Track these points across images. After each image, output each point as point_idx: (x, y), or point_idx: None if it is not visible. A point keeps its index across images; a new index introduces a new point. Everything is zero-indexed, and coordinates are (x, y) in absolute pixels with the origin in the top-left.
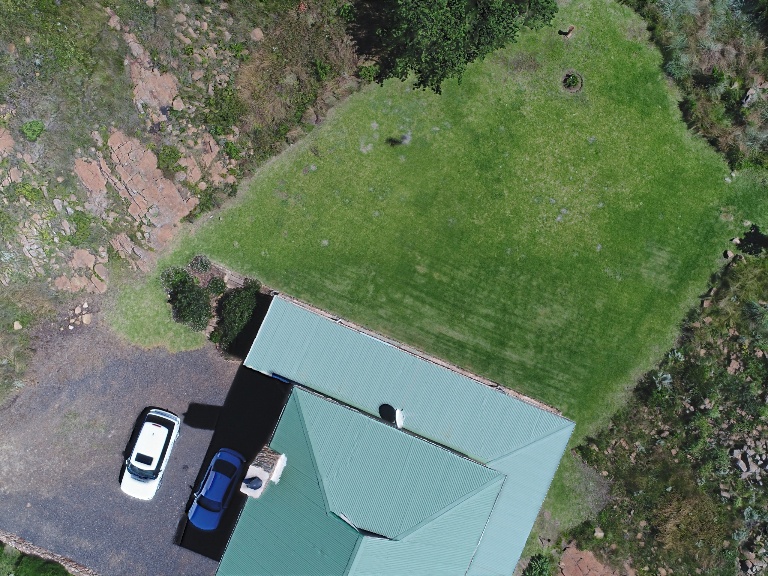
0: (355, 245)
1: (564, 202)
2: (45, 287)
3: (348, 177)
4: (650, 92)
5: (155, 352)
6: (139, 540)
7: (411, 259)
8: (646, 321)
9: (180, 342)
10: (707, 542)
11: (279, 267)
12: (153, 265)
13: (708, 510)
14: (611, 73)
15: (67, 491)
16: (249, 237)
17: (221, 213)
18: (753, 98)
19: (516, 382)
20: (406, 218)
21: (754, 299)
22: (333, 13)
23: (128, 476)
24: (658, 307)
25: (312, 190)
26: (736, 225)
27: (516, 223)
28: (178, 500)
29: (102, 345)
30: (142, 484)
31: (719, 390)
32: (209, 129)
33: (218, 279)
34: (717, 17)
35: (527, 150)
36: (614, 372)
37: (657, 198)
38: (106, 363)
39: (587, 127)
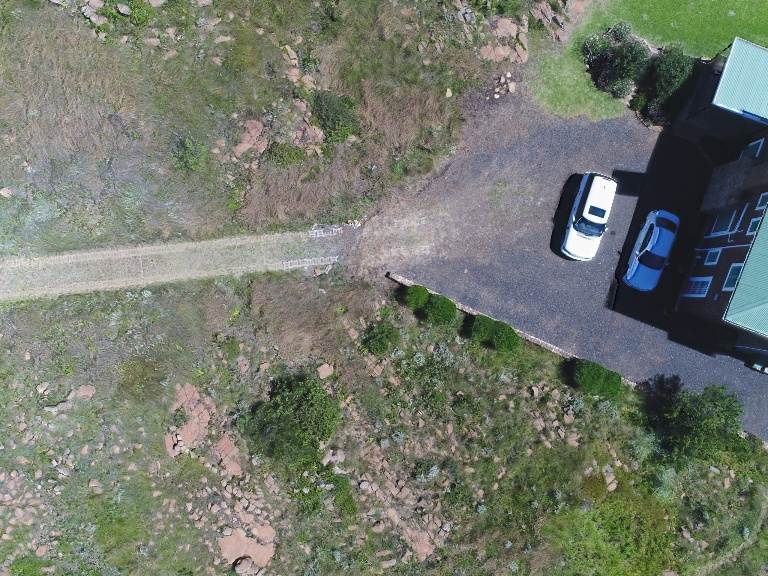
0: (761, 15)
1: None
2: (472, 56)
3: None
4: None
5: (576, 121)
6: (573, 305)
7: None
8: None
9: (601, 110)
10: None
11: (689, 37)
12: (570, 35)
13: None
14: None
15: (501, 257)
16: (657, 9)
17: None
18: None
19: None
20: None
21: None
22: None
23: (574, 234)
24: None
25: None
26: None
27: None
28: (607, 266)
29: (526, 114)
30: (588, 241)
31: None
32: None
33: (644, 42)
34: None
35: None
36: None
37: None
38: (531, 132)
39: None
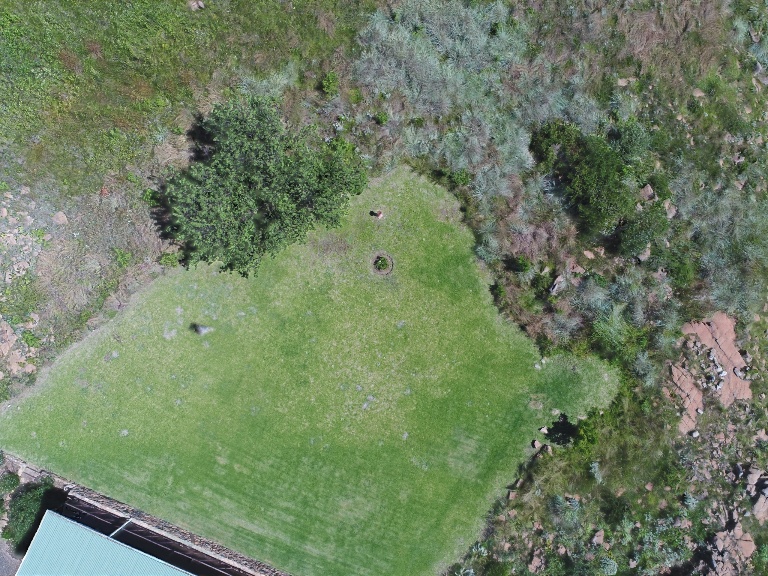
0: (155, 435)
1: (371, 389)
2: None
3: (150, 364)
4: (461, 276)
5: None
6: None
7: (212, 449)
8: (451, 512)
9: None
10: None
11: (77, 458)
12: None
13: None
14: (422, 255)
15: None
16: (47, 427)
17: (19, 402)
18: (560, 287)
19: None
20: (208, 406)
21: (559, 492)
22: (138, 196)
23: None
24: (464, 498)
25: (113, 378)
26: (545, 414)
27: (321, 411)
28: None
29: None
30: None
31: None
32: (6, 318)
33: (7, 477)
34: (529, 200)
35: (334, 335)
36: (417, 565)
37: (466, 385)
38: None
39: (396, 311)
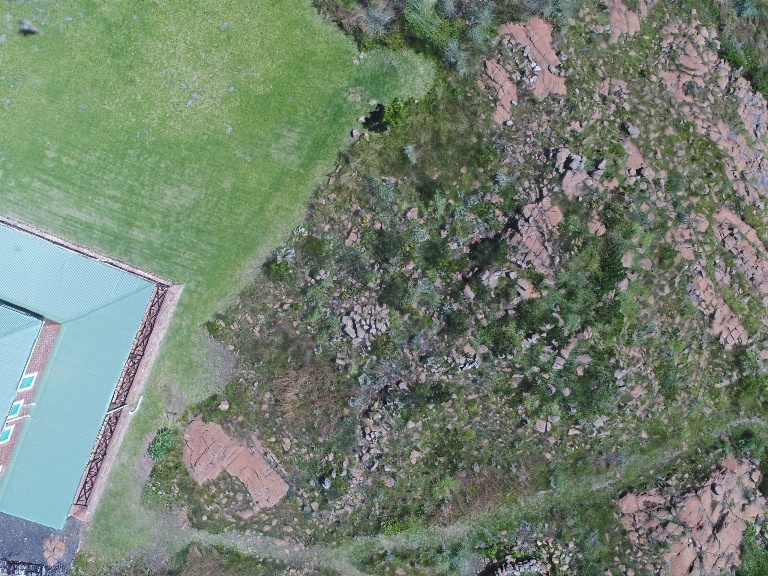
0: None
1: (195, 87)
2: None
3: None
4: None
5: None
6: None
7: (40, 144)
8: (274, 200)
9: None
10: (323, 409)
11: None
12: None
13: (325, 378)
14: None
15: None
16: None
17: None
18: None
19: (143, 261)
20: (37, 105)
21: (376, 175)
22: None
23: None
24: (287, 186)
25: None
26: (363, 105)
27: (147, 108)
28: None
29: None
30: None
31: (335, 261)
32: None
33: None
34: None
35: (159, 38)
36: (242, 250)
37: (287, 81)
38: None
39: (219, 14)
